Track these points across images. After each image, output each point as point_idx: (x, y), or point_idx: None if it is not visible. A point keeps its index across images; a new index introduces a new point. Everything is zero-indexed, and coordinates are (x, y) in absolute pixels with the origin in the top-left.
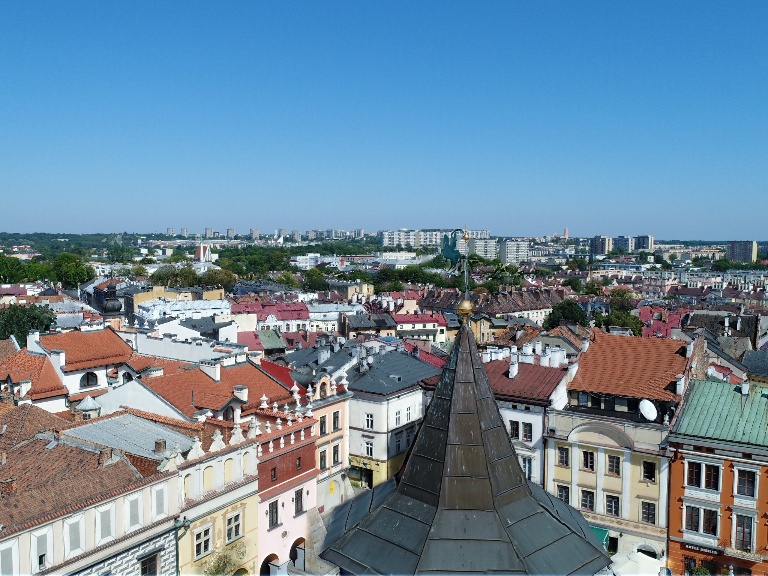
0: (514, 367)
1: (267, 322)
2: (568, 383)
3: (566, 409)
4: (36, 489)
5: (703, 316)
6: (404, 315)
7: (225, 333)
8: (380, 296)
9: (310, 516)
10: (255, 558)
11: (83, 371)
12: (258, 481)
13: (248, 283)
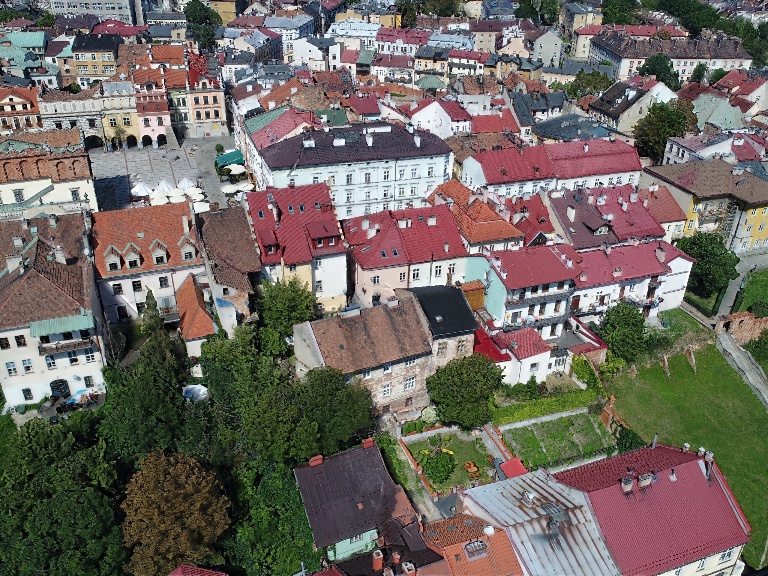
0: (248, 87)
1: (397, 44)
2: (261, 98)
3: (257, 109)
4: (70, 95)
5: (623, 84)
6: (462, 51)
7: (333, 50)
8: (513, 31)
9: (167, 128)
10: (139, 134)
11: (159, 63)
12: (137, 109)
13: (491, 3)
